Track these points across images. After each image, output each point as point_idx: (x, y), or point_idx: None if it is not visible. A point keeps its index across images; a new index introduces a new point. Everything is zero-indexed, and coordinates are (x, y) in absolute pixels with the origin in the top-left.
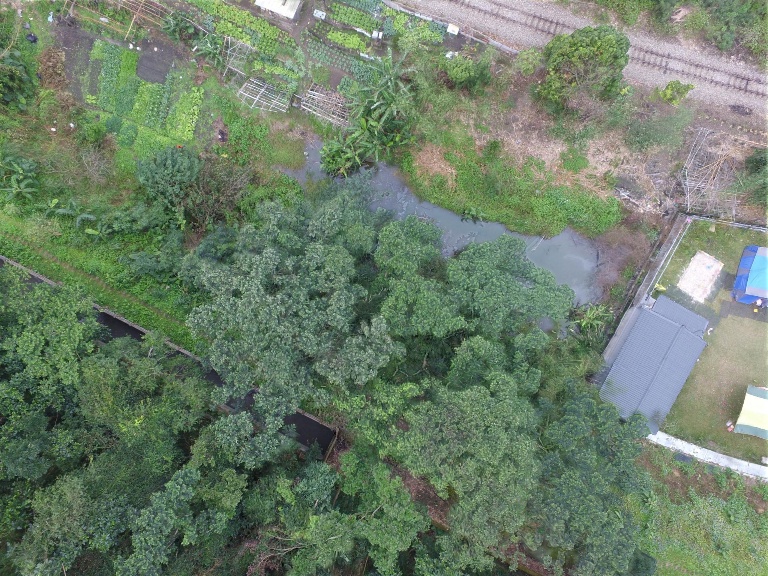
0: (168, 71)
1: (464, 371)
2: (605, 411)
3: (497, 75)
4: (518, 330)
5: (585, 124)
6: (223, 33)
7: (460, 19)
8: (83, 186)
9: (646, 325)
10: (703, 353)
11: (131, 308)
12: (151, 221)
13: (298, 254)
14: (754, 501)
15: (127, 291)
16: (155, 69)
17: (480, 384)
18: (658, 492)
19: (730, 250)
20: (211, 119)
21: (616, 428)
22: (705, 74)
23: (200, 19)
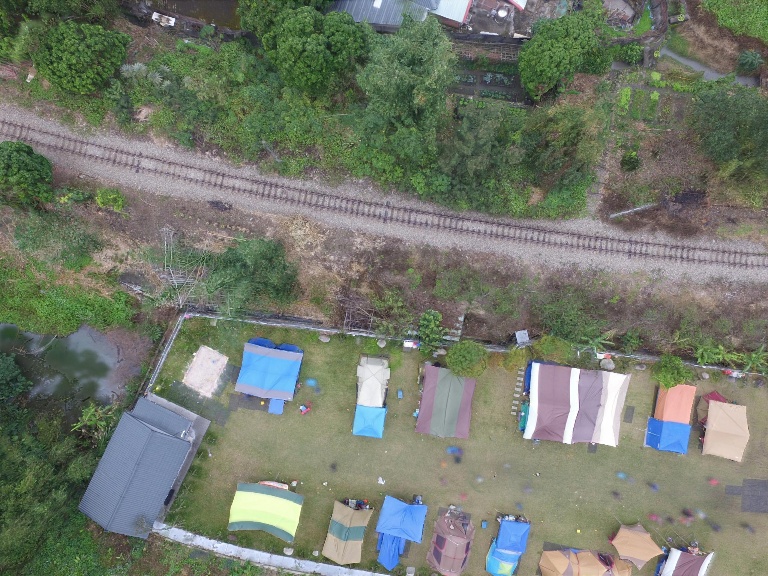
0: None
1: None
2: None
3: None
4: None
5: (74, 224)
6: None
7: None
8: None
9: (124, 429)
10: (215, 448)
11: None
12: None
13: None
14: None
15: None
16: None
17: None
18: None
19: (234, 343)
20: None
21: None
22: (179, 171)
23: None
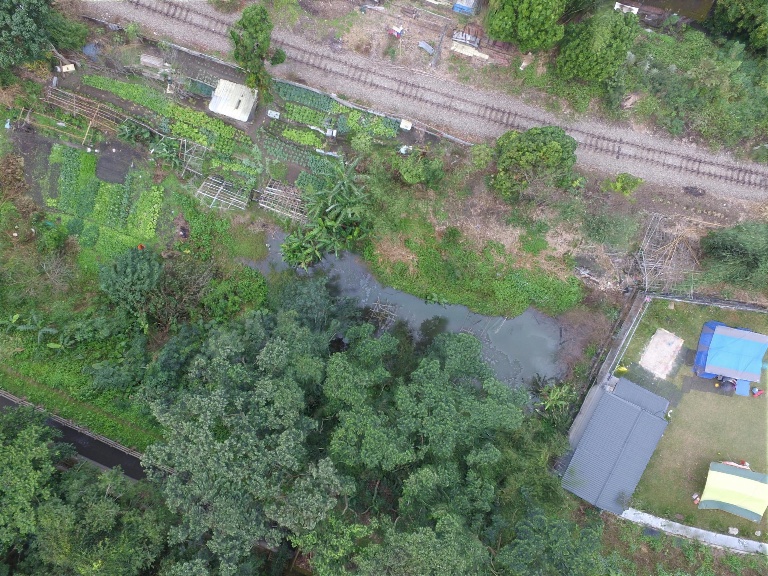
0: (127, 171)
1: (416, 497)
2: (557, 528)
3: (452, 166)
4: (472, 443)
5: (542, 208)
6: (179, 134)
7: (413, 113)
8: (45, 294)
9: (607, 408)
10: (667, 428)
11: (95, 420)
12: (113, 330)
13: (248, 389)
14: (721, 573)
15: (90, 403)
16: (114, 170)
17: (427, 522)
18: (625, 571)
19: (690, 326)
20: (172, 216)
21: (567, 545)
22: (657, 157)
23: (156, 122)
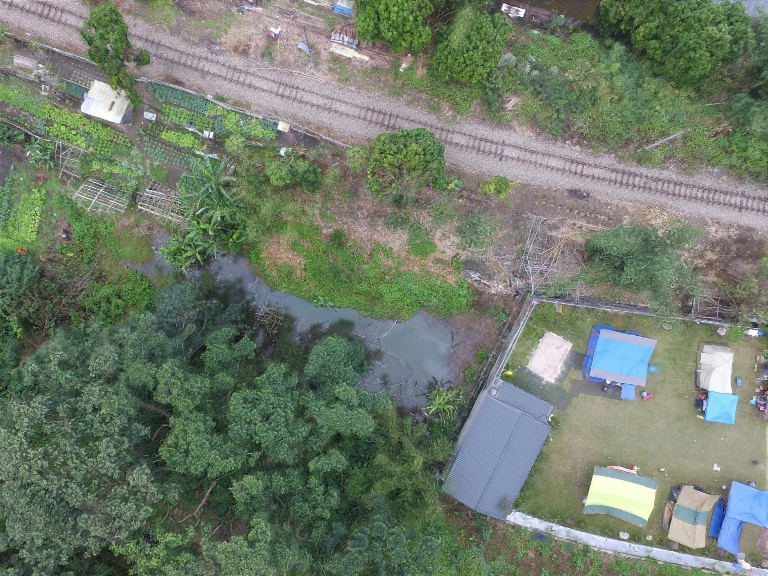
0: (8, 173)
1: (248, 505)
2: (395, 535)
3: (334, 168)
4: (320, 450)
5: (427, 211)
6: (57, 136)
7: (293, 114)
8: None
9: (489, 413)
10: (556, 432)
11: None
12: None
13: (77, 395)
14: None
15: None
16: None
17: (244, 530)
18: None
19: (578, 330)
20: (54, 219)
21: (405, 553)
22: (541, 160)
23: (32, 123)
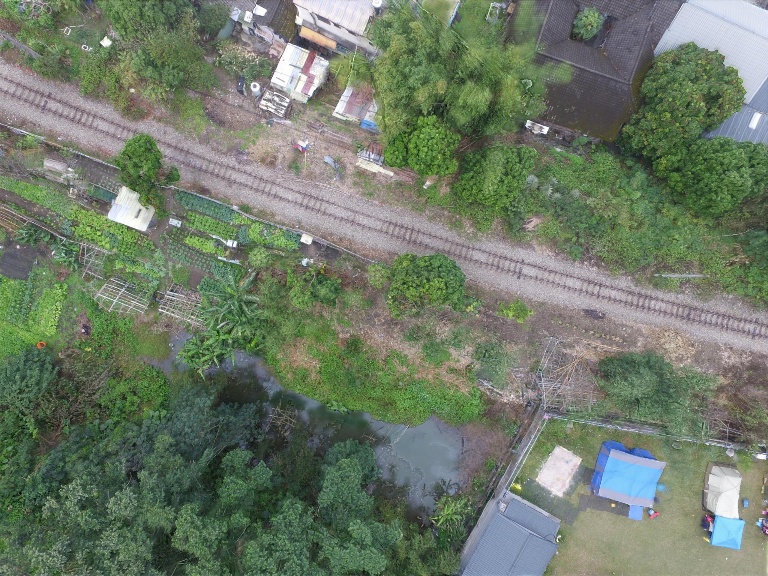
0: (31, 267)
1: None
2: None
3: (354, 279)
4: None
5: (444, 322)
6: (82, 236)
7: (316, 225)
8: None
9: (497, 530)
10: (562, 546)
11: None
12: None
13: (96, 538)
14: None
15: None
16: (18, 266)
17: None
18: None
19: (588, 445)
20: (74, 314)
21: None
22: (558, 279)
23: (59, 223)
